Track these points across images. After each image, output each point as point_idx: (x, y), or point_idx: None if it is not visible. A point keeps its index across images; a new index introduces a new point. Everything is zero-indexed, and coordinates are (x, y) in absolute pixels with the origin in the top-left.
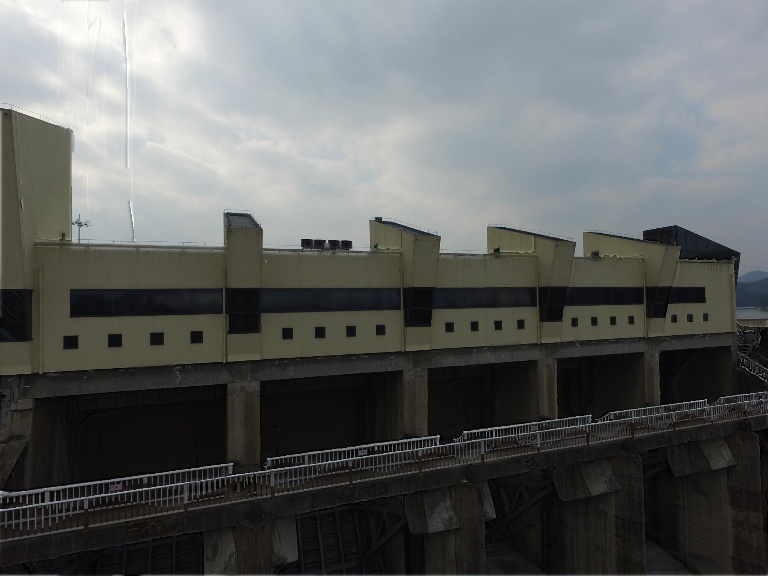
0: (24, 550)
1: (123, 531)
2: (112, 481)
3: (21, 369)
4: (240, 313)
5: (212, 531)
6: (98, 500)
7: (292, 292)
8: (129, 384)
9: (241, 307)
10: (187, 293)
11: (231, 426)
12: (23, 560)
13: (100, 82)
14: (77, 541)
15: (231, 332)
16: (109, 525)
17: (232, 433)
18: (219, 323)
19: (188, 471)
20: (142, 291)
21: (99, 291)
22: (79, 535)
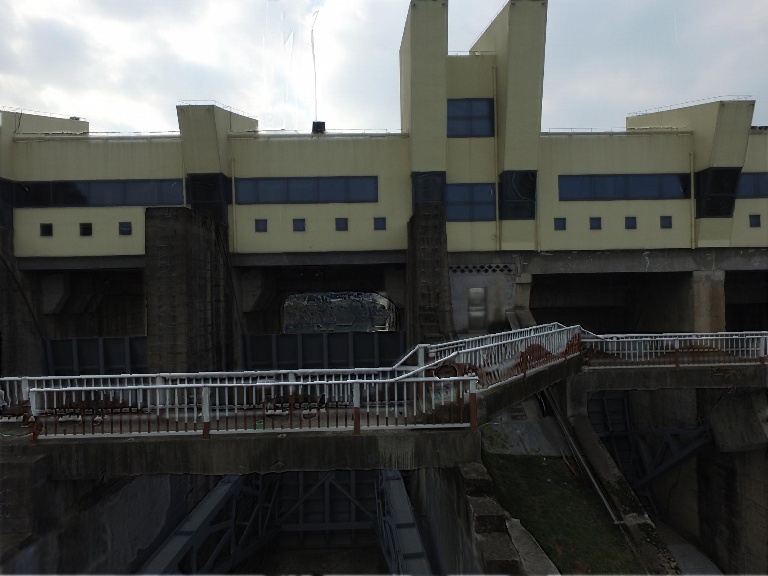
0: (631, 378)
1: (709, 374)
2: (665, 335)
3: (528, 245)
4: (716, 195)
5: (766, 394)
6: (686, 342)
7: (758, 177)
8: (605, 266)
9: (718, 189)
10: (656, 178)
11: (697, 314)
12: (630, 387)
13: (294, 89)
14: (671, 377)
15: (704, 216)
16: (696, 367)
17: (698, 322)
18: (686, 208)
19: (731, 334)
20: (616, 176)
21: (581, 177)
22: (673, 372)
